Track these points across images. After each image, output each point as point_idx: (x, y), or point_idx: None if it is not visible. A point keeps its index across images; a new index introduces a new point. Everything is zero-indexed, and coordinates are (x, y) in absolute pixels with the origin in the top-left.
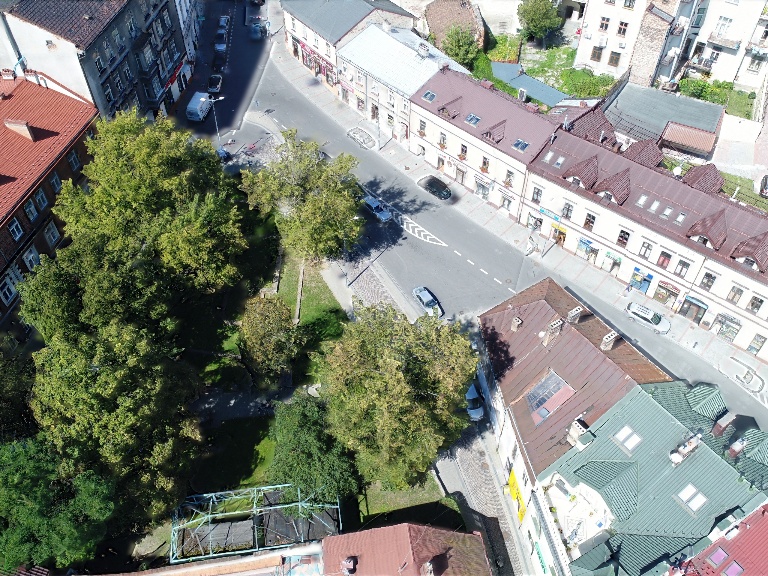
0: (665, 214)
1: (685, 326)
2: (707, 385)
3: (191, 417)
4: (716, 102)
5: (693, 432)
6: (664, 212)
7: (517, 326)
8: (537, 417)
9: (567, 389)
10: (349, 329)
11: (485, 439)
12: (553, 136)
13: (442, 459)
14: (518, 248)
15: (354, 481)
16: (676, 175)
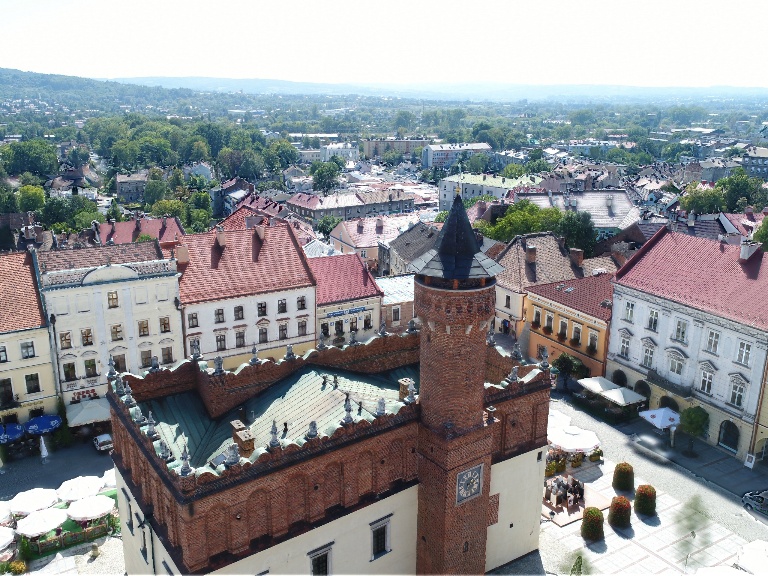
0: None
1: None
2: None
3: (729, 210)
4: None
5: None
6: None
7: None
8: None
9: None
10: None
11: None
12: None
13: None
14: None
15: None
16: None
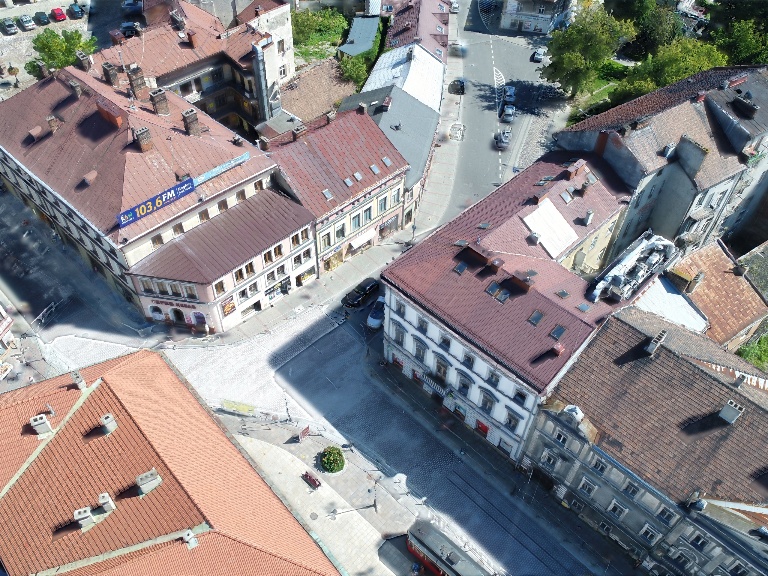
0: None
1: None
2: None
3: None
4: None
5: None
6: None
7: None
8: None
9: None
10: None
11: None
12: None
13: None
14: (461, 49)
15: None
16: None
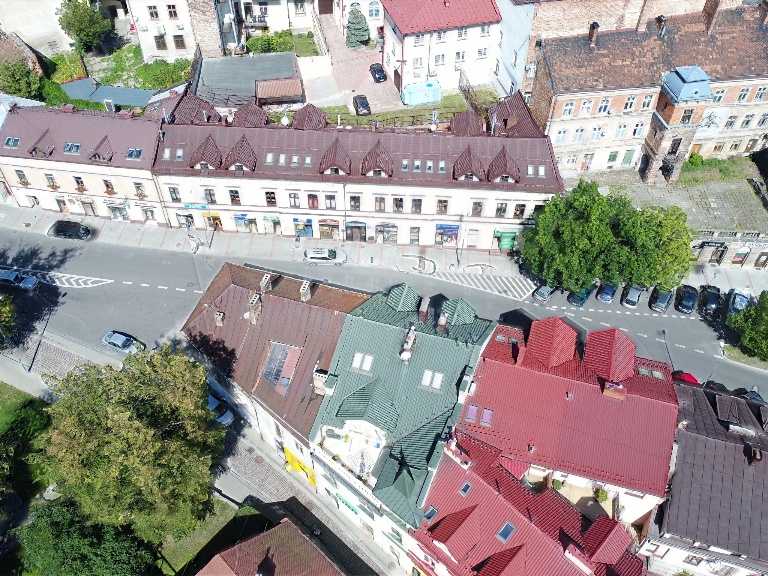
0: (294, 162)
1: (357, 249)
2: (397, 287)
3: None
4: (285, 50)
5: (407, 328)
6: (292, 161)
7: (221, 320)
8: (281, 389)
9: (293, 351)
10: (56, 411)
11: (246, 436)
12: (161, 133)
13: (217, 478)
14: (183, 251)
15: (144, 552)
16: (286, 125)
